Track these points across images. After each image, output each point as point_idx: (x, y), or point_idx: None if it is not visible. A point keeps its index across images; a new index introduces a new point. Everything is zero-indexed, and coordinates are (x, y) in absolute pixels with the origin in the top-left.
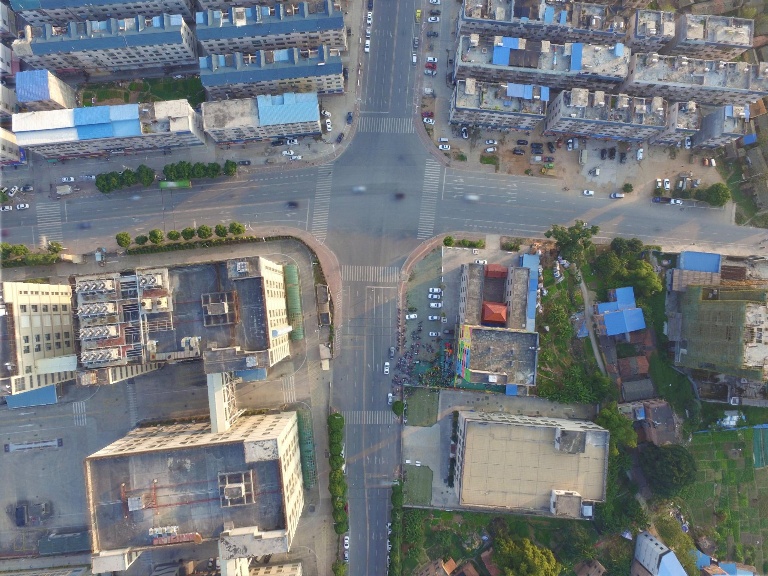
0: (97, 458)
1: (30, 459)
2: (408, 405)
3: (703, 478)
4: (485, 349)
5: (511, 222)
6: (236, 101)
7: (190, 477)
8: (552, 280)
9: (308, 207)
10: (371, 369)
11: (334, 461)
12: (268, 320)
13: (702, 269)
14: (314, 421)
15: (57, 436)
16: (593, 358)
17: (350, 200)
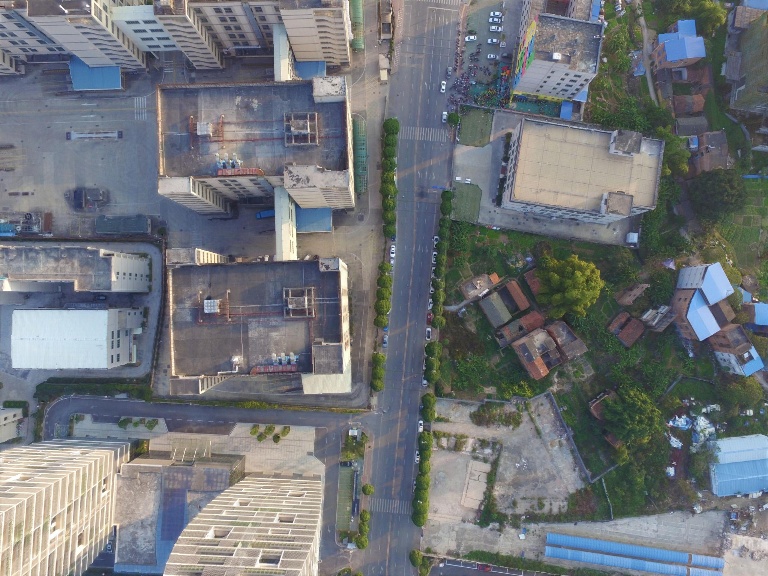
0: None
1: (90, 148)
2: (462, 124)
3: (749, 223)
4: (549, 36)
5: None
6: None
7: (256, 116)
8: (613, 13)
9: None
10: (427, 87)
11: (388, 160)
12: None
13: (766, 8)
14: (368, 133)
15: (117, 128)
16: (648, 96)
17: None
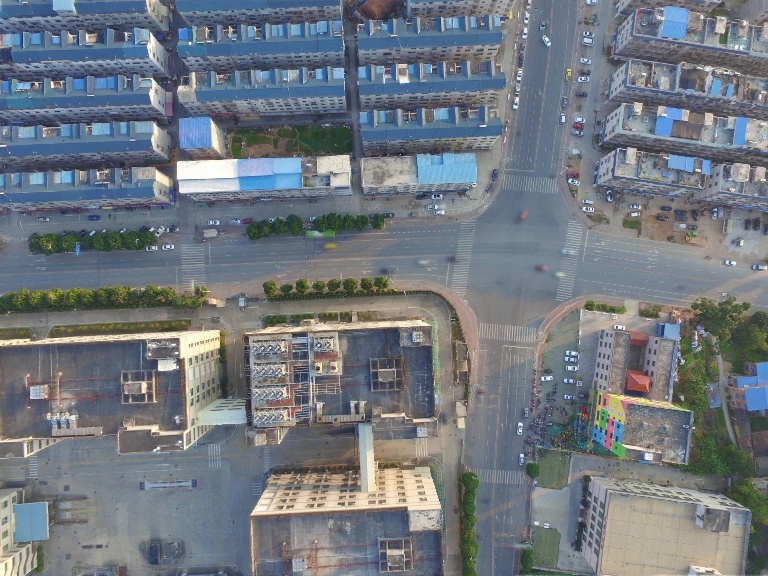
0: (263, 517)
1: (164, 498)
2: (539, 467)
3: None
4: (638, 424)
5: (650, 288)
6: (395, 158)
7: (350, 540)
8: (689, 349)
9: (449, 262)
10: (504, 428)
11: (469, 521)
12: None
13: None
14: (445, 477)
15: (192, 477)
16: (725, 429)
17: (491, 258)
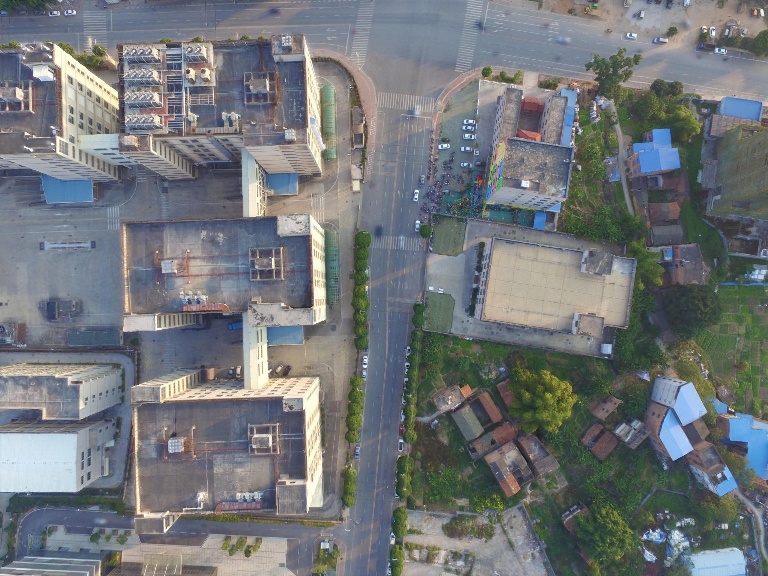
0: None
1: (64, 258)
2: (435, 233)
3: (726, 331)
4: (519, 160)
5: (550, 61)
6: None
7: (222, 250)
8: (588, 120)
9: (349, 32)
10: (400, 196)
11: (359, 275)
12: (307, 103)
13: (742, 116)
14: (341, 242)
15: (91, 238)
16: (623, 203)
17: (391, 28)
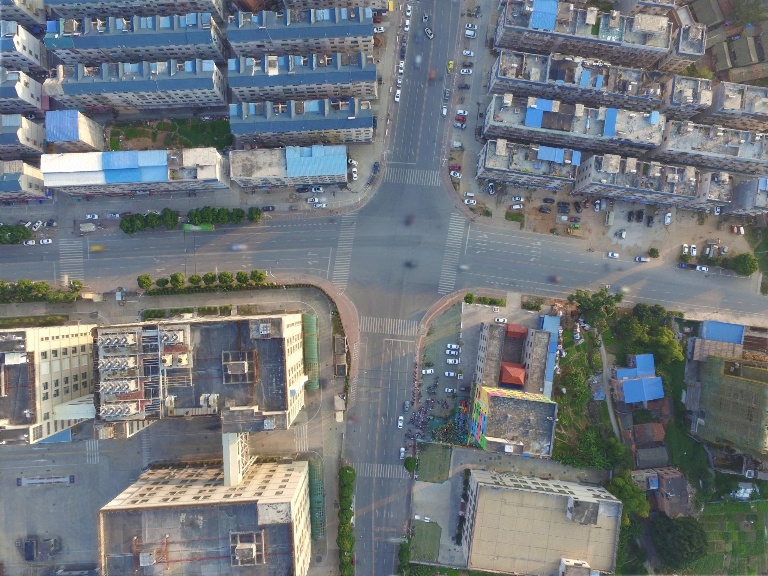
0: (111, 511)
1: (42, 494)
2: (420, 460)
3: (713, 549)
4: (502, 416)
5: (533, 281)
6: (264, 151)
7: (202, 534)
8: (572, 342)
9: (330, 256)
10: (385, 422)
11: (344, 515)
12: (287, 381)
13: (725, 339)
14: (325, 471)
15: (69, 473)
16: (608, 422)
17: (372, 251)
